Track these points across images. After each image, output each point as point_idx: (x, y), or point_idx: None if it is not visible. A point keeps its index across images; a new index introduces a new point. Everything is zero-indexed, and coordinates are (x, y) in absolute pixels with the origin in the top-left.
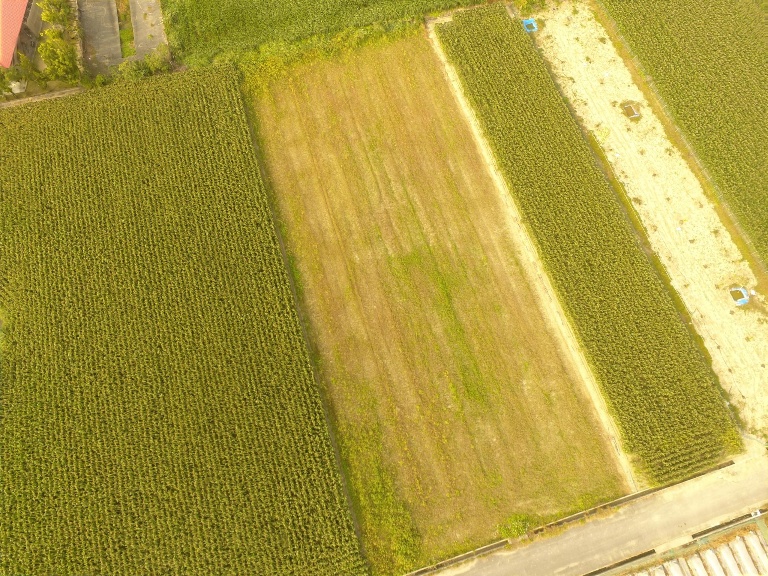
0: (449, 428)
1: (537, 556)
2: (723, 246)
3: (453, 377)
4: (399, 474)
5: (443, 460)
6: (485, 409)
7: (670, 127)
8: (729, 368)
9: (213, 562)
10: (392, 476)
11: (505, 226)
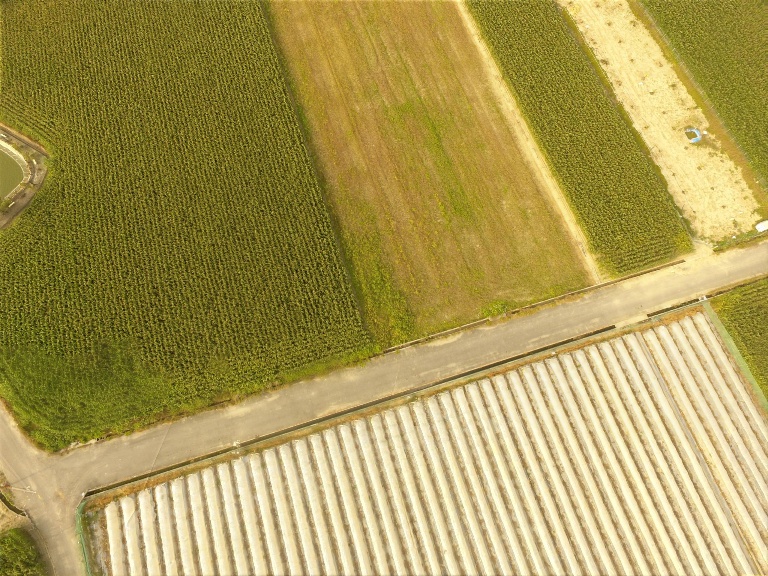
0: (439, 236)
1: (514, 330)
2: (680, 97)
3: (442, 198)
4: (396, 270)
5: (433, 260)
6: (470, 222)
7: (635, 4)
8: (682, 190)
9: (238, 331)
10: (390, 272)
11: (488, 83)
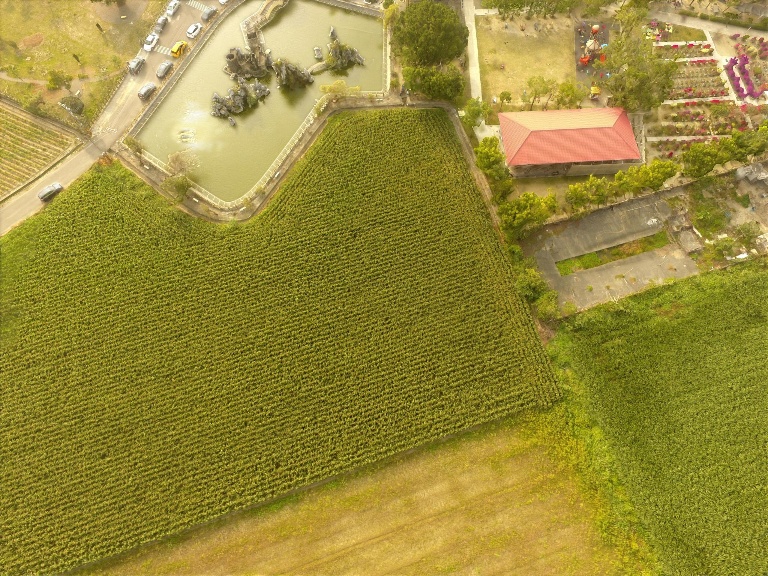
0: None
1: None
2: None
3: None
4: None
5: None
6: None
7: None
8: None
9: None
10: None
11: None
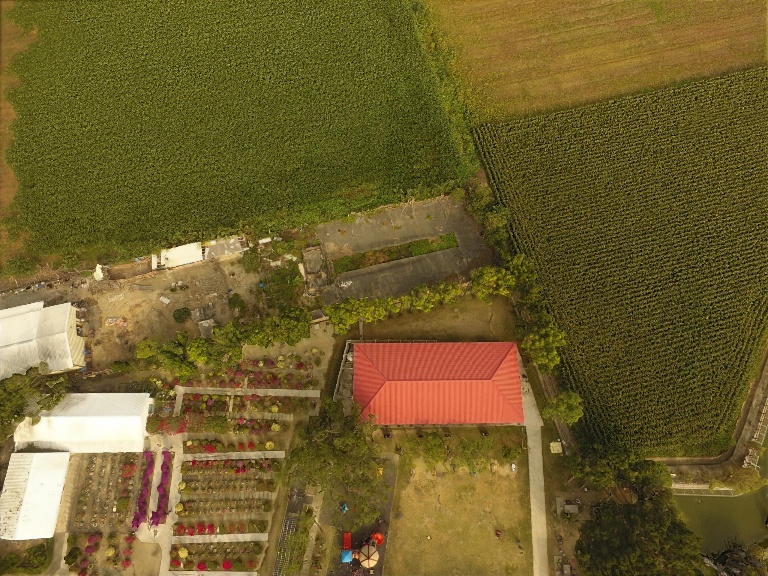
0: None
1: None
2: None
3: None
4: None
5: None
6: None
7: None
8: None
9: None
10: None
11: None
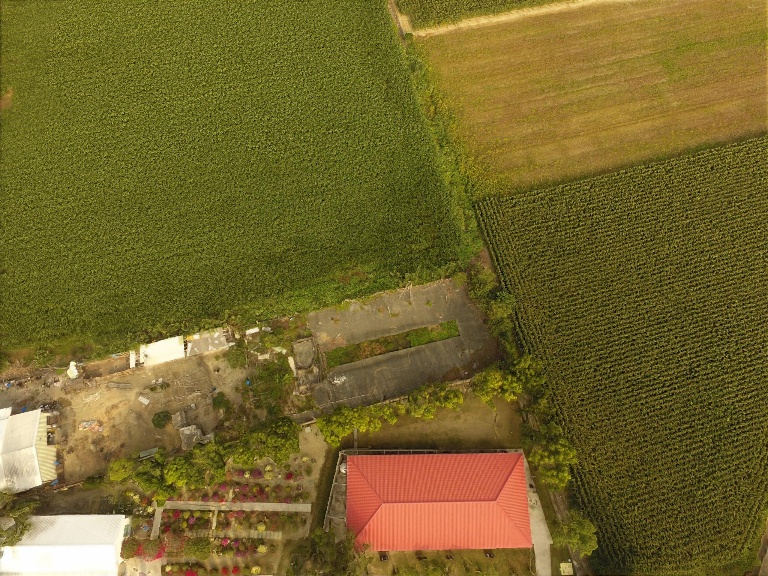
0: None
1: None
2: None
3: (759, 47)
4: None
5: None
6: None
7: None
8: None
9: None
10: None
11: (626, 3)
